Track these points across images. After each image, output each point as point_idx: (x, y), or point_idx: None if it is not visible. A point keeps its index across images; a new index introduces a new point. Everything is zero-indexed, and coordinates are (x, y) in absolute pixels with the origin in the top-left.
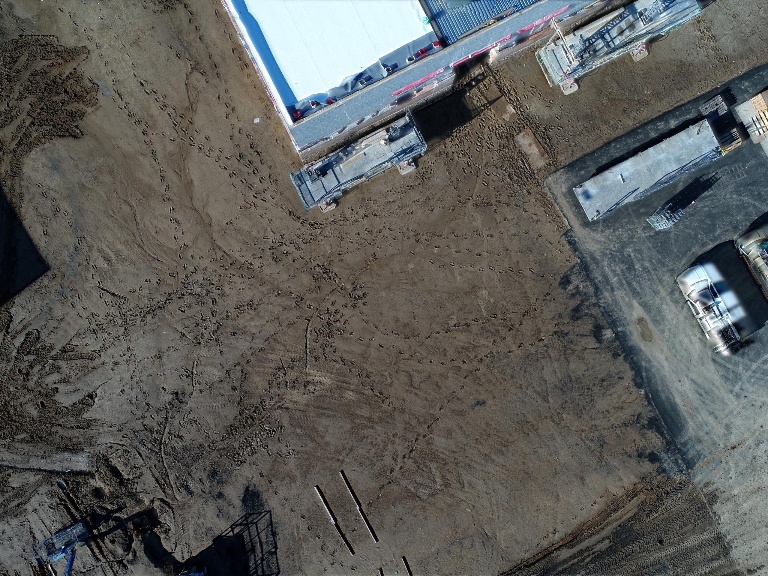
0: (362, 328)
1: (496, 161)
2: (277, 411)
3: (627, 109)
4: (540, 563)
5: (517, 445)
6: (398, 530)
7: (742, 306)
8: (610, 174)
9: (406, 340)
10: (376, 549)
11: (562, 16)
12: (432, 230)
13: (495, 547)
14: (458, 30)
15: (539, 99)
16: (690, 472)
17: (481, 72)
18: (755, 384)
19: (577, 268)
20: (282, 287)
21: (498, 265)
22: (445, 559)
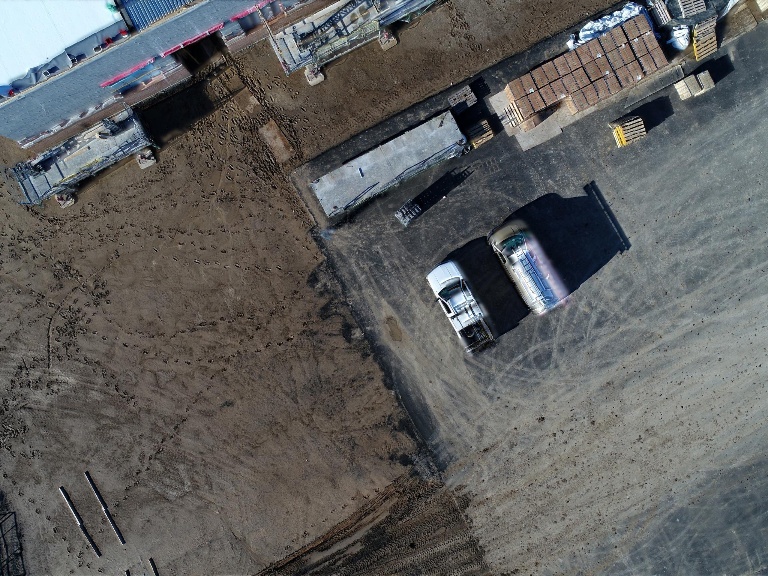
0: (105, 327)
1: (240, 155)
2: (20, 411)
3: (376, 100)
4: (290, 566)
5: (266, 446)
6: (145, 532)
7: (495, 305)
8: (348, 168)
9: (151, 339)
10: (123, 551)
11: (291, 3)
12: (175, 226)
13: (244, 549)
14: (150, 19)
15: (284, 90)
16: (441, 474)
17: (223, 62)
18: (508, 385)
19: (324, 265)
20: (22, 285)
21: (244, 262)
22: (193, 561)
